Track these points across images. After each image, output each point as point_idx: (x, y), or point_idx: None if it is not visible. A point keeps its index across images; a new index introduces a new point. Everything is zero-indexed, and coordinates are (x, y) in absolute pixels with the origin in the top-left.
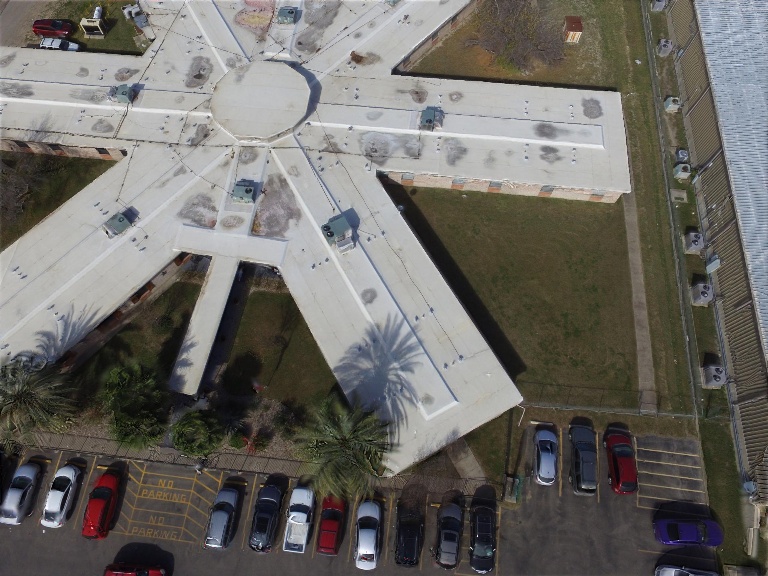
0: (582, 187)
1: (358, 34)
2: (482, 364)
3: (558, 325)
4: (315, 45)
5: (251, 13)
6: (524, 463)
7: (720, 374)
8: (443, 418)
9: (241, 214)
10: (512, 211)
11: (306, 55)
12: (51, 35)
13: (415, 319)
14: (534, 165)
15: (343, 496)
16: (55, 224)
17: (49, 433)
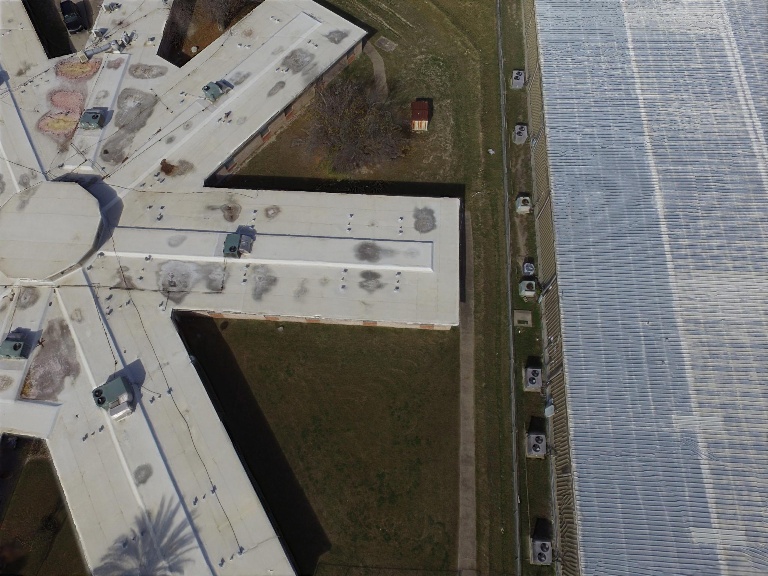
0: (403, 321)
1: (171, 138)
2: (265, 558)
3: (372, 489)
4: (122, 153)
5: (56, 116)
6: None
7: (546, 552)
8: None
9: (11, 373)
10: (333, 345)
11: (111, 166)
12: None
13: (193, 502)
14: (351, 296)
15: None
16: None
17: None
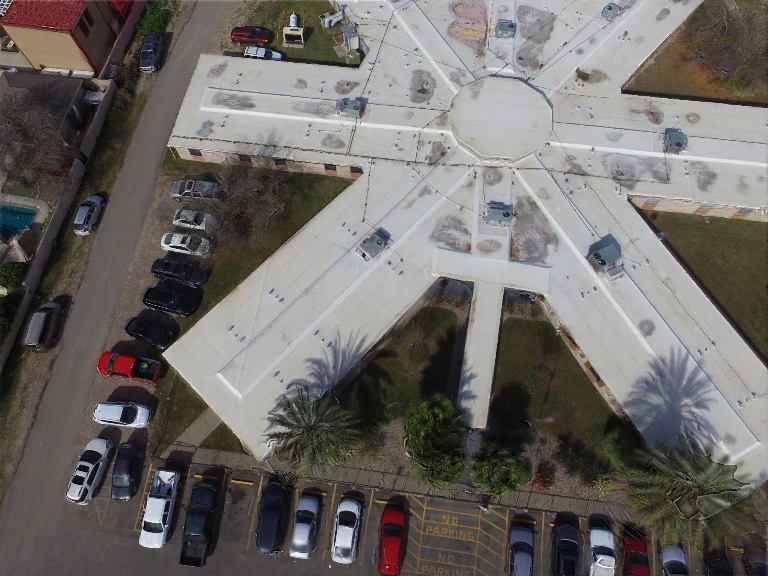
0: None
1: (580, 50)
2: None
3: None
4: (537, 61)
5: (464, 25)
6: None
7: None
8: (747, 459)
9: (497, 238)
10: (759, 239)
11: (530, 71)
12: (249, 43)
13: (699, 353)
14: None
15: (642, 538)
16: (302, 244)
17: (325, 465)
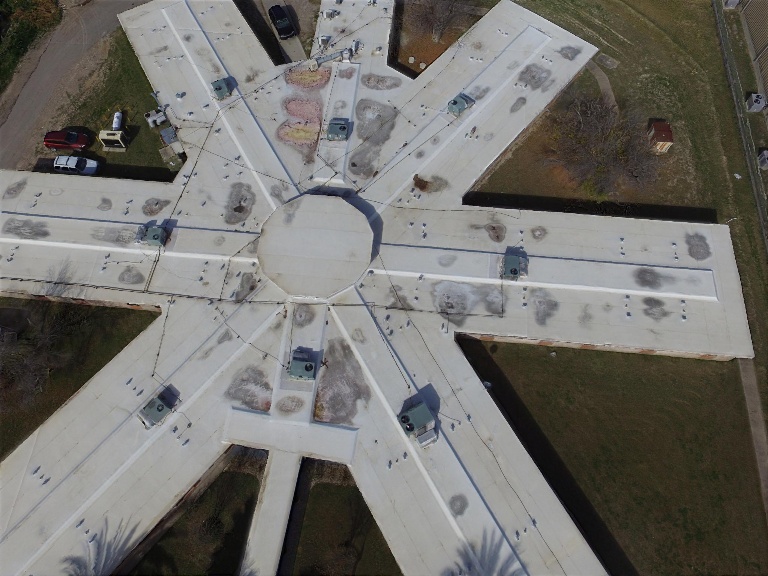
0: (697, 352)
1: (420, 153)
2: None
3: (677, 525)
4: (371, 167)
5: (295, 126)
6: None
7: None
8: None
9: (300, 394)
10: (610, 373)
11: (362, 180)
12: (65, 148)
13: (516, 537)
14: (638, 324)
15: None
16: (81, 407)
17: None
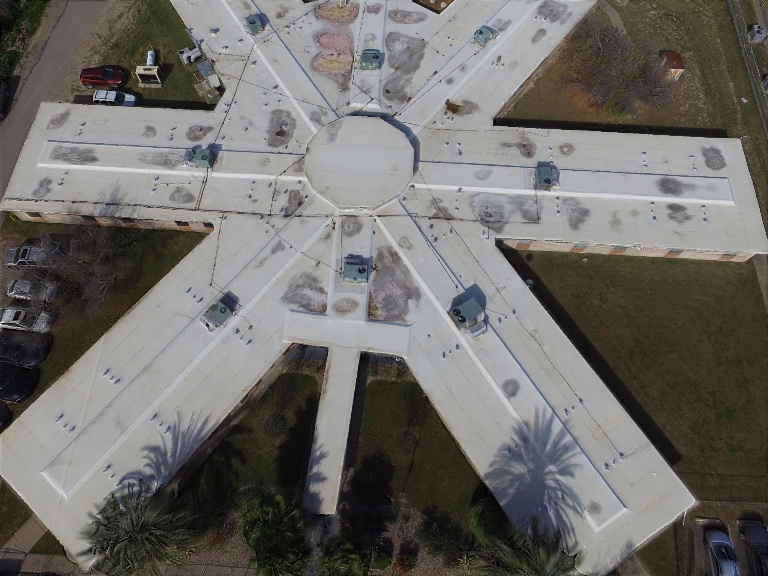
0: (718, 249)
1: (451, 79)
2: (645, 462)
3: (707, 405)
4: (405, 93)
5: (329, 57)
6: (695, 568)
7: None
8: (613, 528)
9: (354, 296)
10: (638, 275)
11: (397, 105)
12: (101, 85)
13: (565, 413)
14: (664, 226)
15: None
16: (143, 315)
17: (165, 565)
